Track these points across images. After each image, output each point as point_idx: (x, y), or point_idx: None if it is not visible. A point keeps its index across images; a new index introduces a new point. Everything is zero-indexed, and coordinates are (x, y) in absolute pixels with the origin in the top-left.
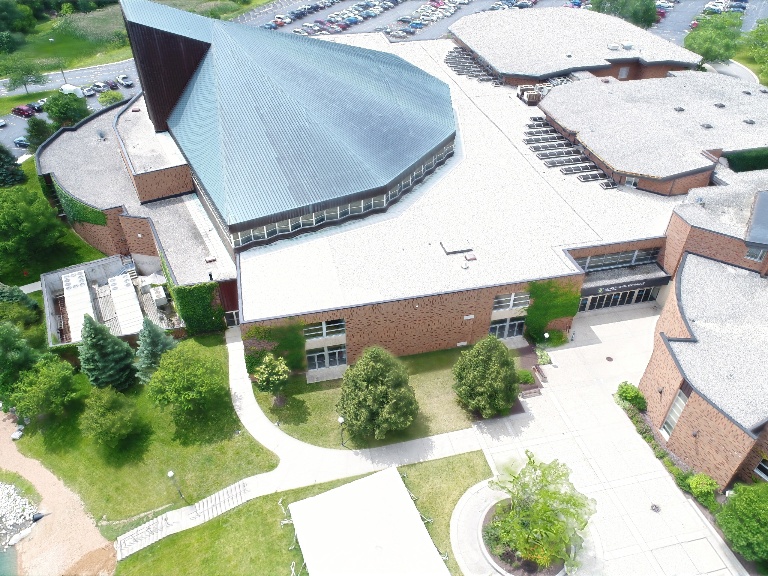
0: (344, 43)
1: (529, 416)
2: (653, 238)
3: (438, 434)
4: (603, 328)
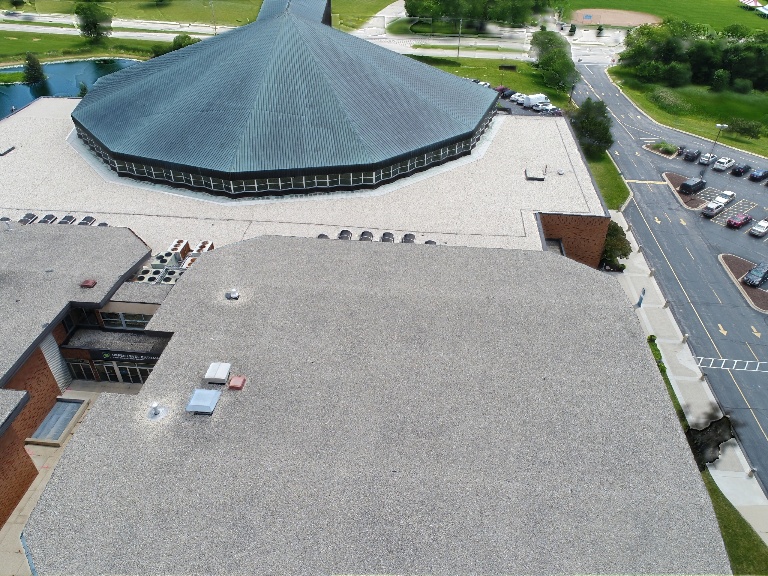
0: (532, 175)
1: None
2: None
3: None
4: None
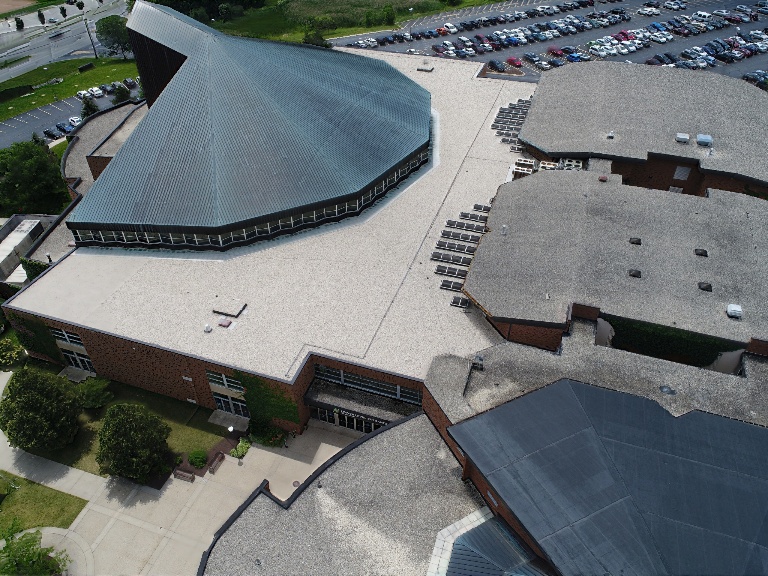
0: (429, 68)
1: (157, 495)
2: (413, 379)
3: (78, 468)
4: (331, 450)
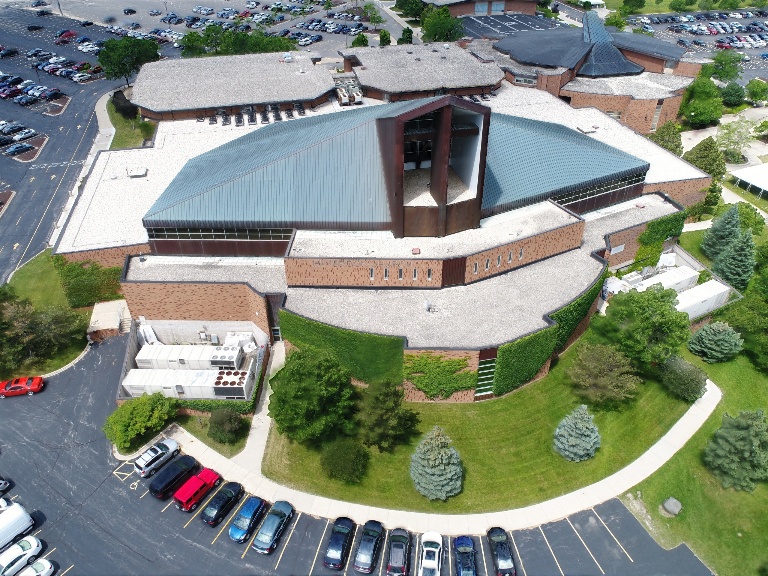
0: (142, 168)
1: None
2: None
3: None
4: None
